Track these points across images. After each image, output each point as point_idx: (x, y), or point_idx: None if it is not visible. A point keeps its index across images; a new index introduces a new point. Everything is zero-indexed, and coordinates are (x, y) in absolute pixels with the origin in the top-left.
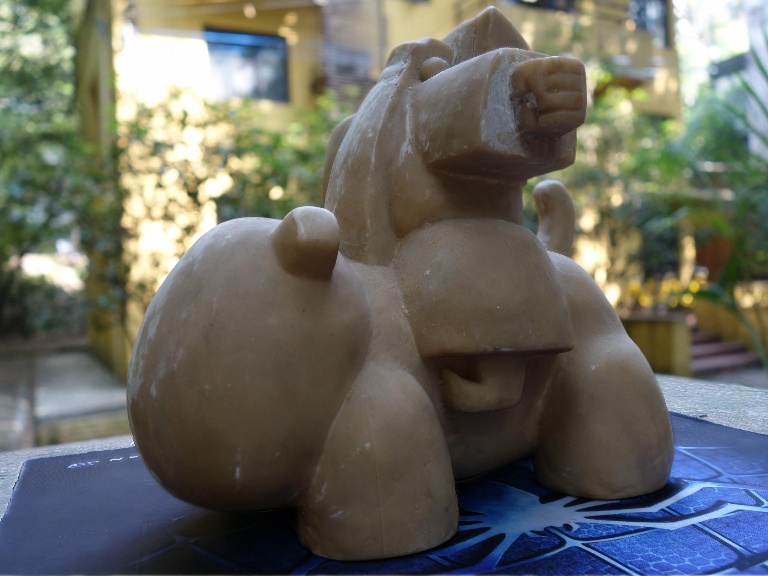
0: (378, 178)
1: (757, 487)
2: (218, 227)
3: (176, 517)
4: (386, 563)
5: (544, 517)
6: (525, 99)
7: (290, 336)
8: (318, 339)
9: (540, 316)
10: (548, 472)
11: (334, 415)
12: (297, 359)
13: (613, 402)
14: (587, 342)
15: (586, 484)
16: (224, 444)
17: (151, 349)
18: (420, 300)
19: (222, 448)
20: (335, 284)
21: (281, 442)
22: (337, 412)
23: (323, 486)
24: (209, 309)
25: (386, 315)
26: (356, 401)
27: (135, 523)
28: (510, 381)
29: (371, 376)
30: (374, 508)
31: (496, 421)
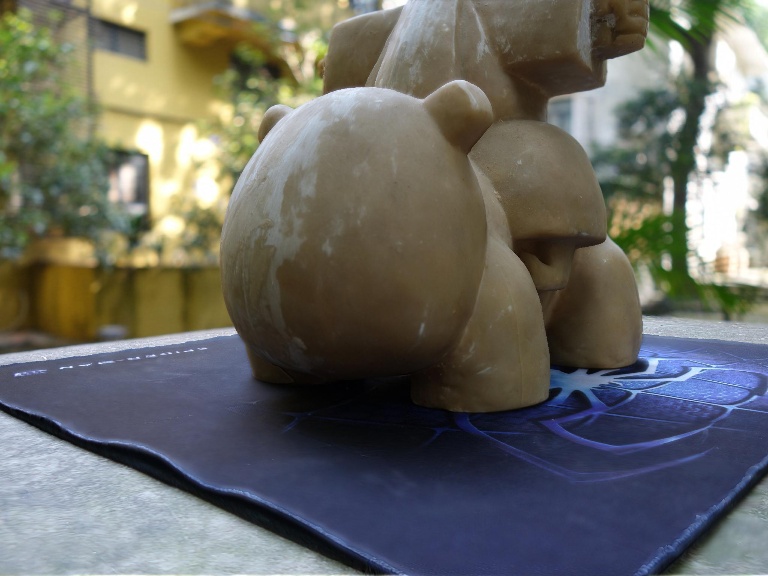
0: (458, 72)
1: (691, 358)
2: (351, 92)
3: (251, 401)
4: (524, 411)
5: (587, 380)
6: (603, 19)
7: (460, 201)
8: (473, 208)
9: (599, 209)
10: (560, 350)
11: (480, 280)
12: (465, 223)
13: (620, 289)
14: None
15: (599, 356)
16: (414, 300)
17: (314, 207)
18: (515, 186)
19: (411, 304)
20: None
21: (457, 300)
22: (481, 278)
23: (471, 346)
24: (389, 168)
25: (488, 198)
26: (493, 269)
27: (214, 408)
28: (568, 265)
29: (495, 249)
30: (517, 363)
31: None
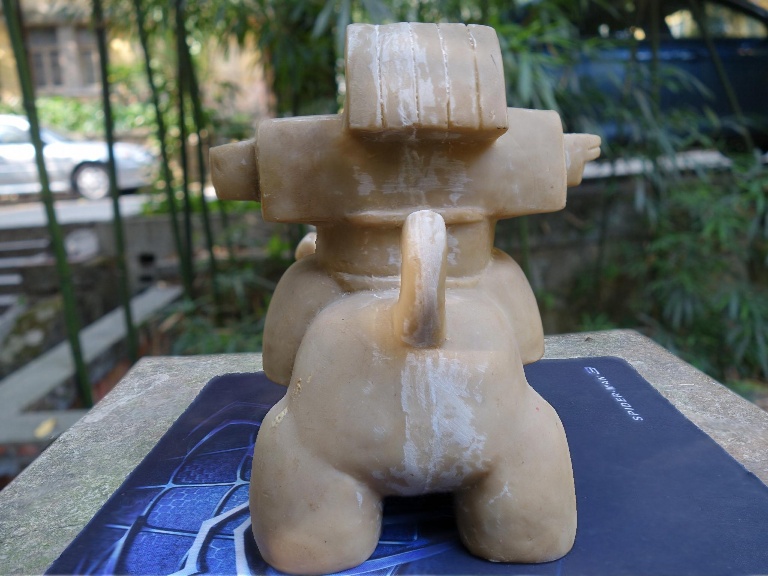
0: None
1: None
2: None
3: None
4: None
5: None
6: None
7: None
8: None
9: None
10: None
11: None
12: None
13: None
14: None
15: None
16: None
17: None
18: None
19: None
20: None
21: None
22: None
23: None
24: None
25: None
26: None
27: None
28: None
29: None
30: None
31: None
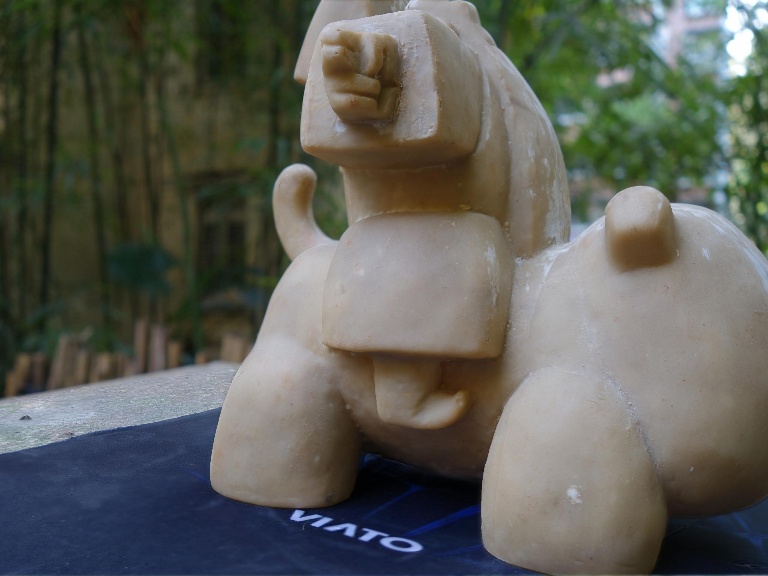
0: None
1: None
2: None
3: (747, 568)
4: None
5: None
6: None
7: None
8: None
9: None
10: None
11: None
12: None
13: None
14: None
15: None
16: None
17: None
18: None
19: None
20: None
21: None
22: None
23: None
24: None
25: None
26: None
27: None
28: None
29: None
30: None
31: None
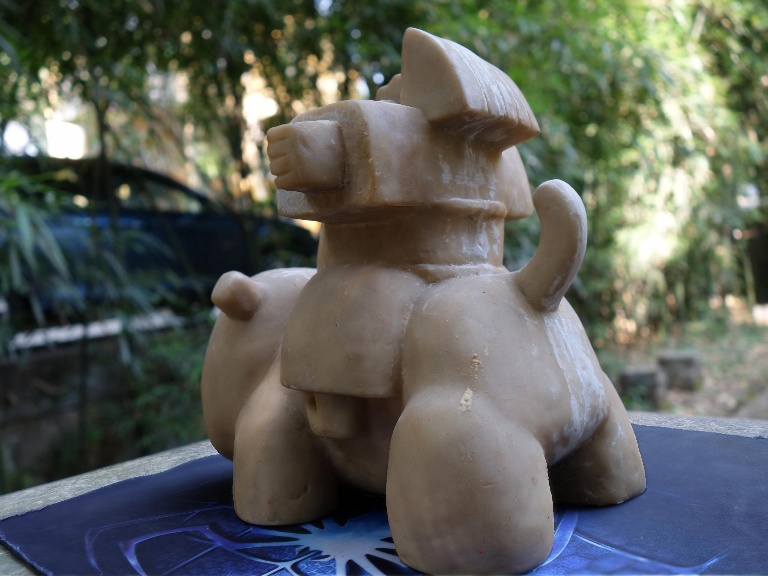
0: None
1: None
2: None
3: None
4: None
5: (342, 545)
6: None
7: (217, 358)
8: (230, 361)
9: (316, 361)
10: None
11: (238, 413)
12: (218, 373)
13: (397, 460)
14: (416, 391)
15: None
16: None
17: None
18: None
19: None
20: (252, 323)
21: (212, 423)
22: (240, 412)
23: None
24: None
25: None
26: (245, 407)
27: None
28: (330, 415)
29: (259, 391)
30: (234, 481)
31: (368, 450)
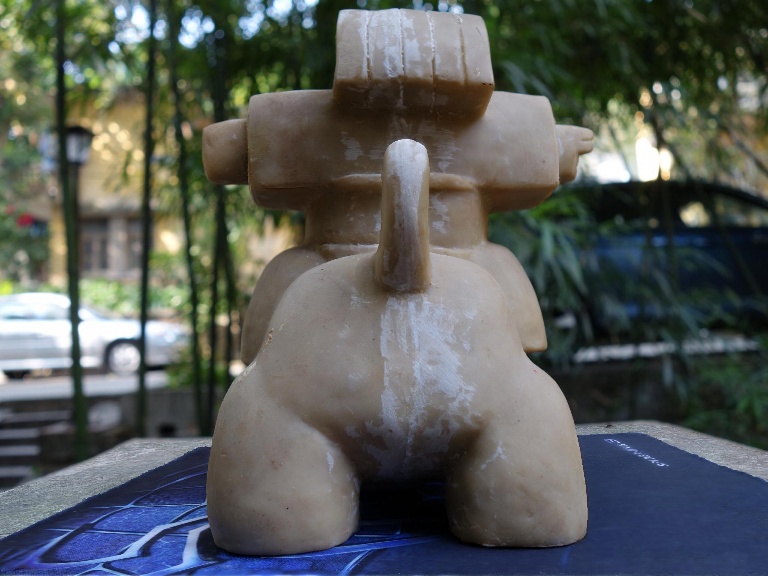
0: None
1: None
2: None
3: None
4: None
5: None
6: None
7: None
8: None
9: None
10: None
11: None
12: None
13: None
14: None
15: None
16: None
17: None
18: None
19: None
20: None
21: None
22: None
23: None
24: None
25: None
26: None
27: None
28: None
29: None
30: None
31: None
